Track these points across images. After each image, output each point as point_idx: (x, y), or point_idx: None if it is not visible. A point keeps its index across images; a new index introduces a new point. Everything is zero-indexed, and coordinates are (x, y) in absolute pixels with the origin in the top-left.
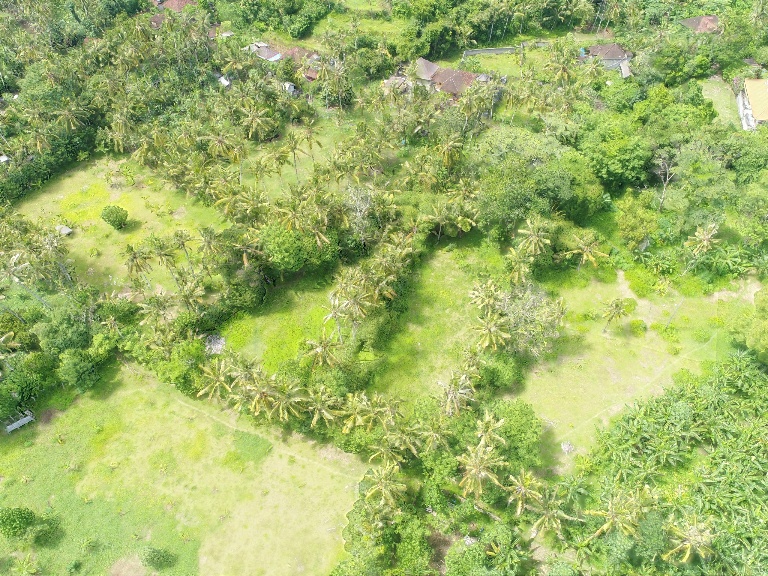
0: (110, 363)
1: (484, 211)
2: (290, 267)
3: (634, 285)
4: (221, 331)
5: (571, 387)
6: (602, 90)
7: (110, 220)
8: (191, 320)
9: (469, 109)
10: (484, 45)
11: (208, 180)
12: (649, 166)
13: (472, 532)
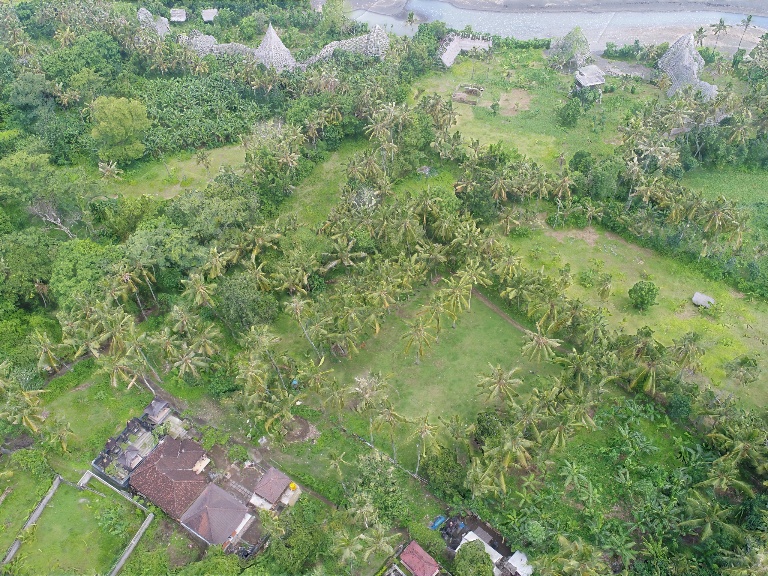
0: None
1: None
2: None
3: None
4: None
5: None
6: None
7: None
8: None
9: None
10: None
11: None
12: None
13: None
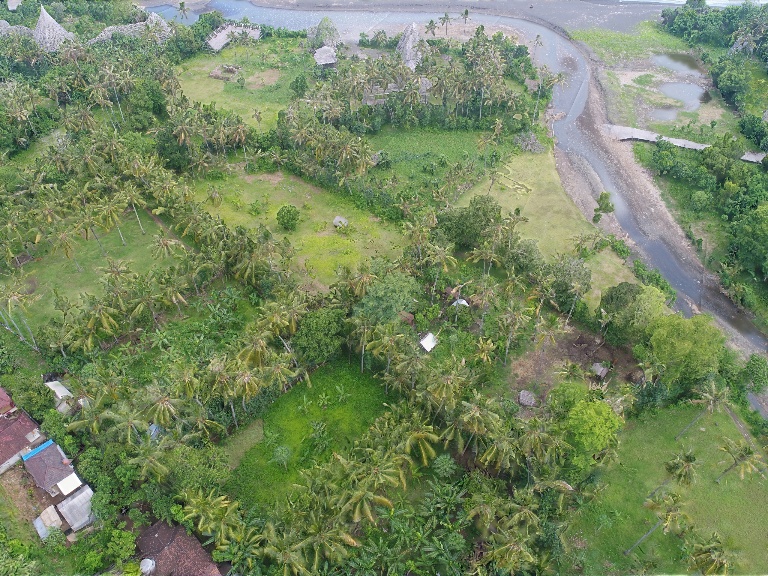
0: None
1: None
2: None
3: None
4: None
5: None
6: None
7: None
8: None
9: None
10: None
11: None
12: None
13: None
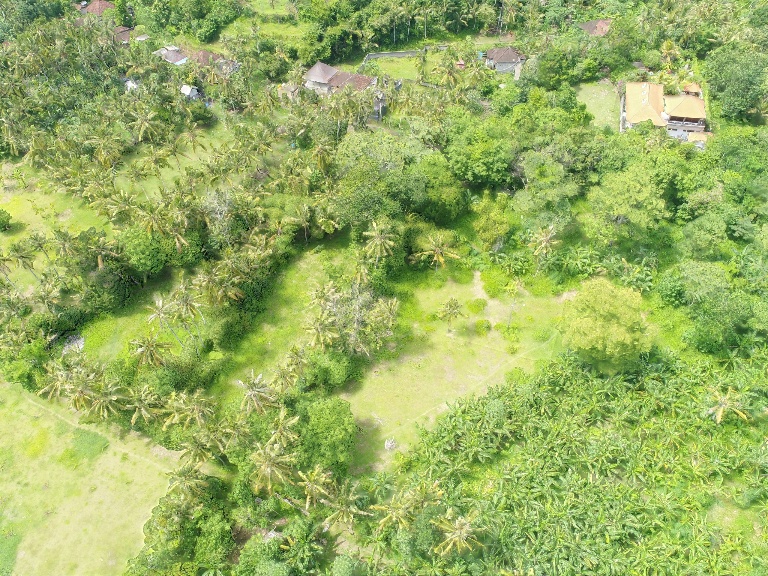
0: None
1: None
2: (148, 269)
3: (487, 286)
4: (81, 331)
5: (406, 386)
6: (493, 93)
7: None
8: (45, 321)
9: (338, 113)
10: (388, 48)
11: (85, 183)
12: (515, 169)
13: (282, 527)
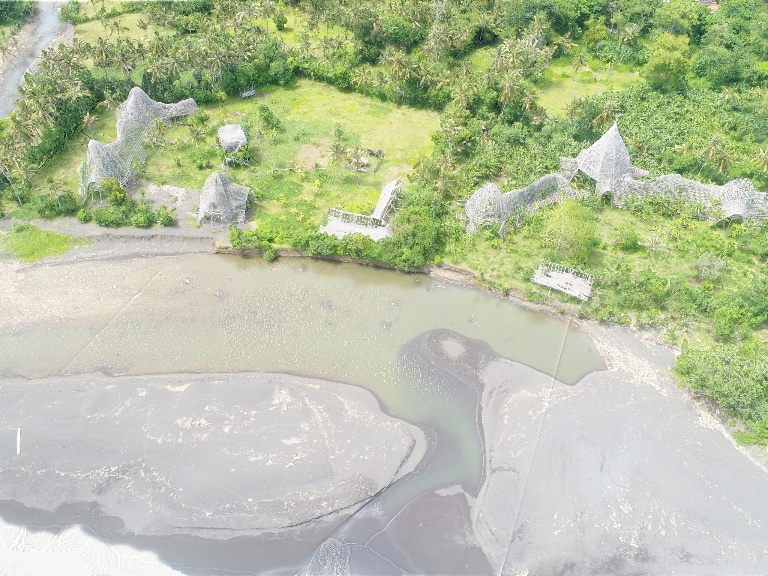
0: (292, 79)
1: (509, 19)
2: (397, 37)
3: (592, 66)
4: None
5: (554, 98)
6: None
7: (278, 20)
8: None
9: None
10: None
11: None
12: (605, 13)
13: None
